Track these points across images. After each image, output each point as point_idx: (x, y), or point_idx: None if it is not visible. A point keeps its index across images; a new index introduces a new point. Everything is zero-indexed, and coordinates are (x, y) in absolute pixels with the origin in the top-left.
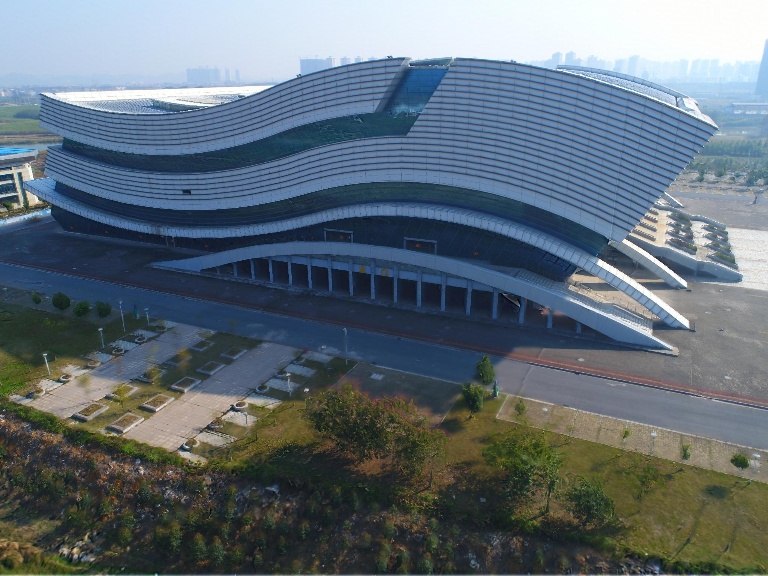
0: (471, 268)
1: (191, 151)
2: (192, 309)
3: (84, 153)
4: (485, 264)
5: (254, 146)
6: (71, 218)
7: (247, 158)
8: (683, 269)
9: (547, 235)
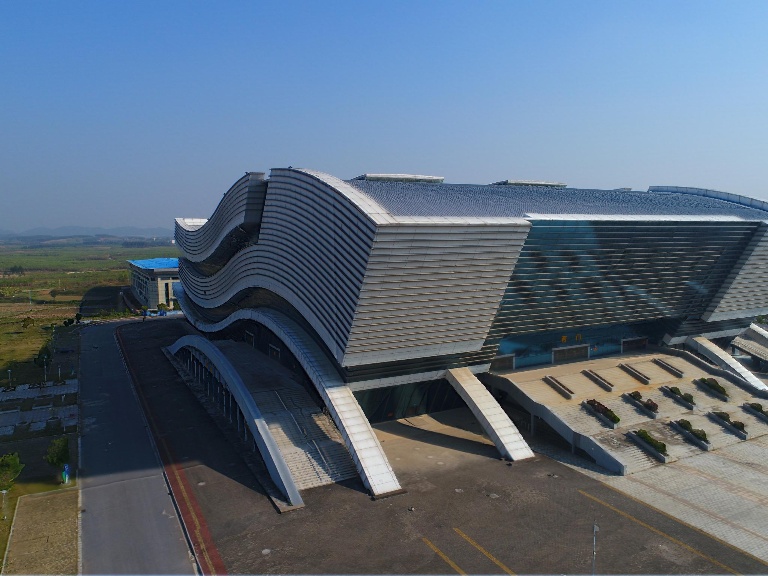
0: (226, 371)
1: None
2: (108, 377)
3: None
4: (287, 377)
5: (218, 254)
6: None
7: (224, 265)
8: (561, 440)
9: (317, 351)
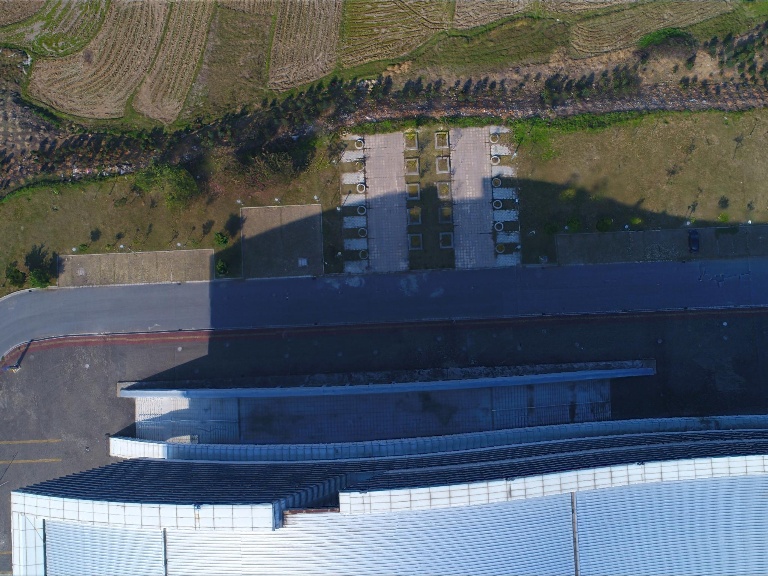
0: (268, 390)
1: None
2: (514, 296)
3: None
4: (274, 442)
5: None
6: None
7: None
8: None
9: None
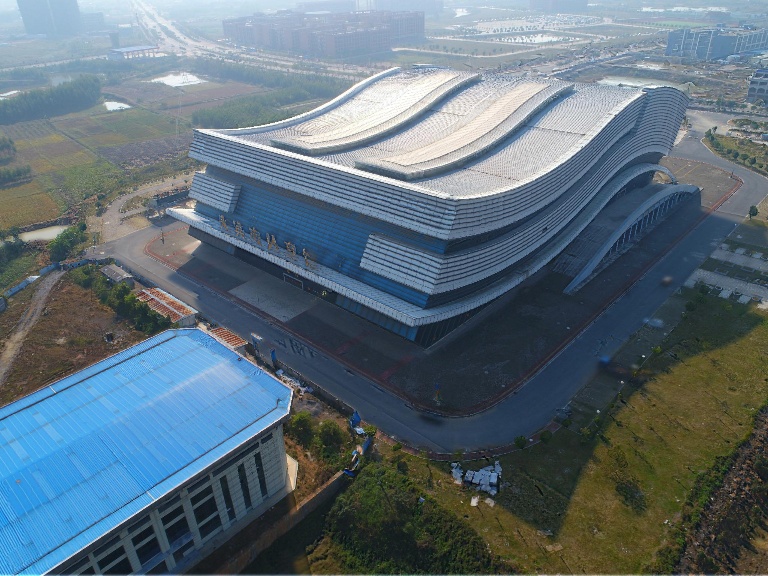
0: None
1: (560, 193)
2: (662, 277)
3: (454, 248)
4: None
5: None
6: (437, 328)
7: None
8: None
9: None
